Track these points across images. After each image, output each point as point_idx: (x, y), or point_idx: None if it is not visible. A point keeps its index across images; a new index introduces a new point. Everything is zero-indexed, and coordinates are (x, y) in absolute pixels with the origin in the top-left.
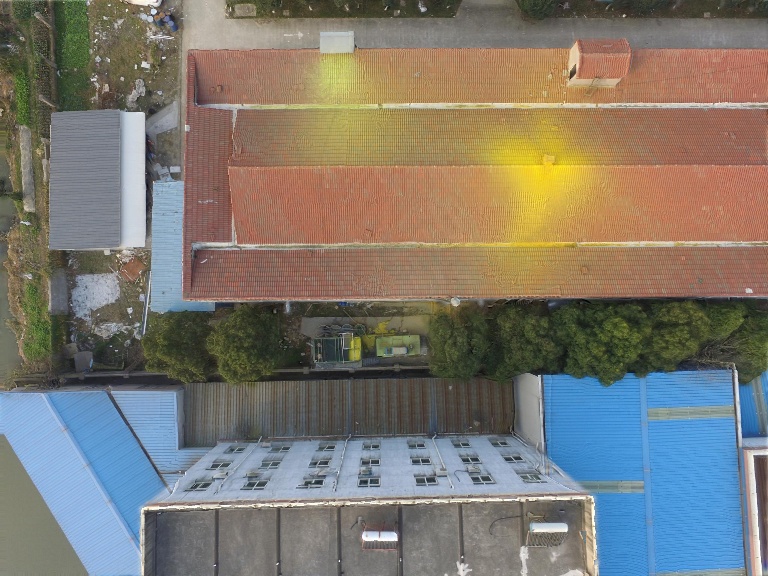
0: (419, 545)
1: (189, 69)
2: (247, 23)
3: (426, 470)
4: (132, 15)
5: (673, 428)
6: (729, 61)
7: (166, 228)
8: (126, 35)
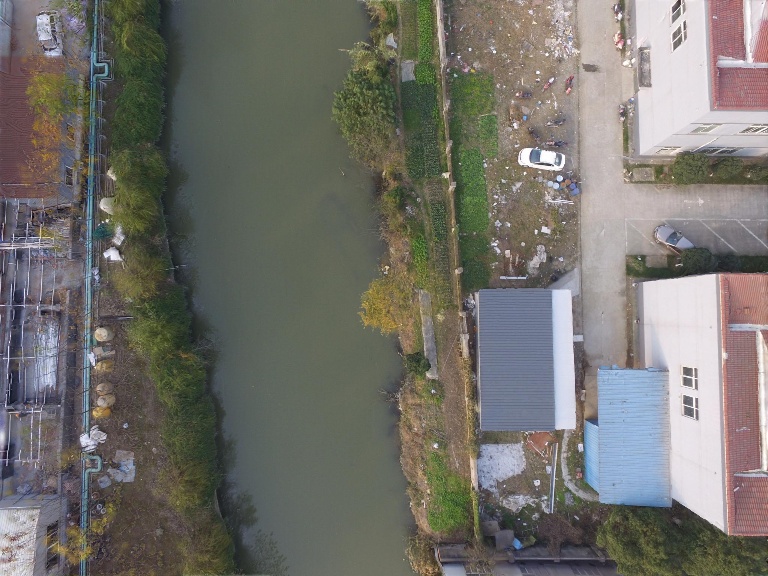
0: None
1: (725, 294)
2: (646, 188)
3: None
4: (530, 178)
5: None
6: None
7: (614, 418)
8: (525, 199)
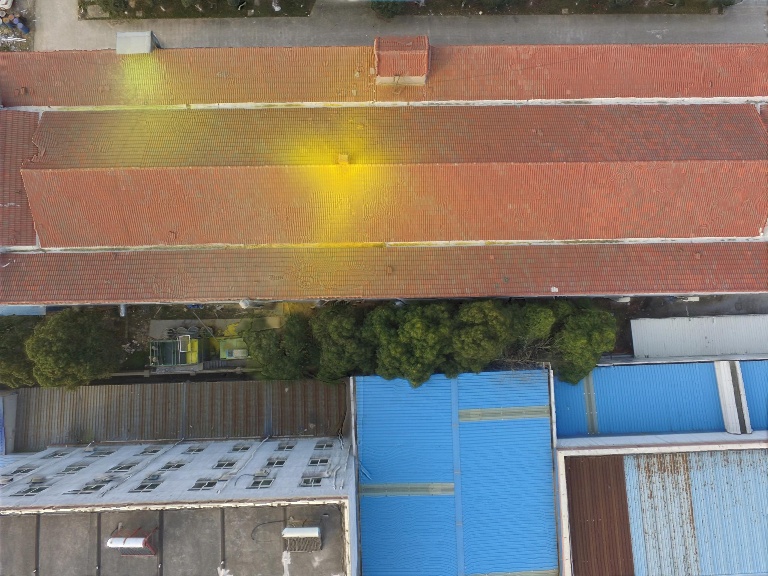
0: (180, 551)
1: None
2: (99, 24)
3: (216, 474)
4: None
5: (485, 429)
6: (537, 57)
7: None
8: None
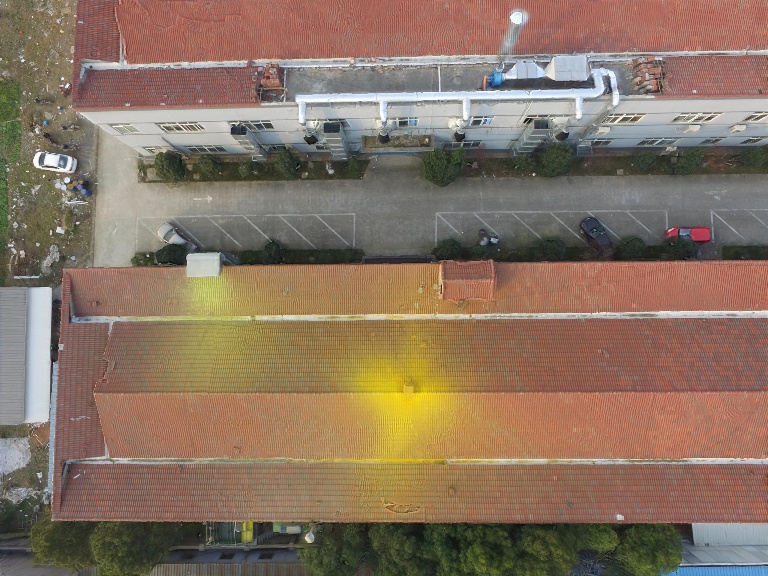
0: None
1: (64, 287)
2: (158, 187)
3: None
4: (49, 181)
5: None
6: (603, 276)
7: None
8: (42, 201)
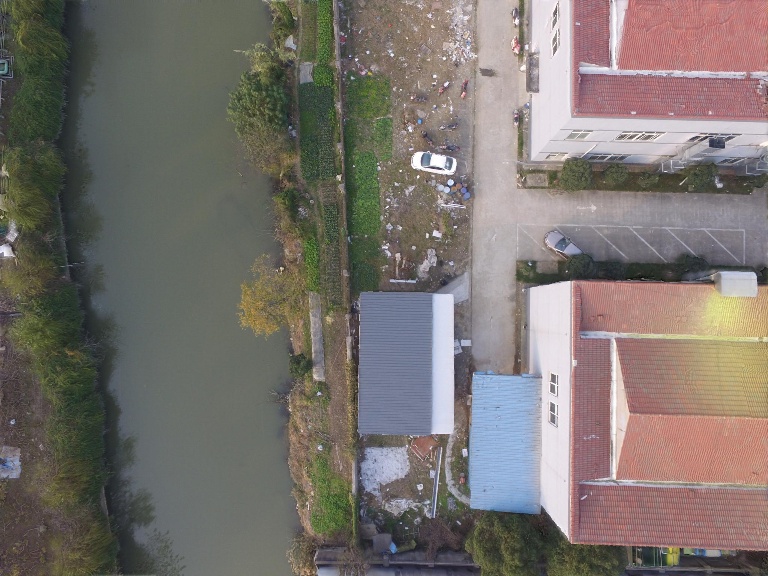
0: None
1: (576, 301)
2: (539, 194)
3: None
4: (423, 182)
5: None
6: None
7: (487, 423)
8: (417, 202)
